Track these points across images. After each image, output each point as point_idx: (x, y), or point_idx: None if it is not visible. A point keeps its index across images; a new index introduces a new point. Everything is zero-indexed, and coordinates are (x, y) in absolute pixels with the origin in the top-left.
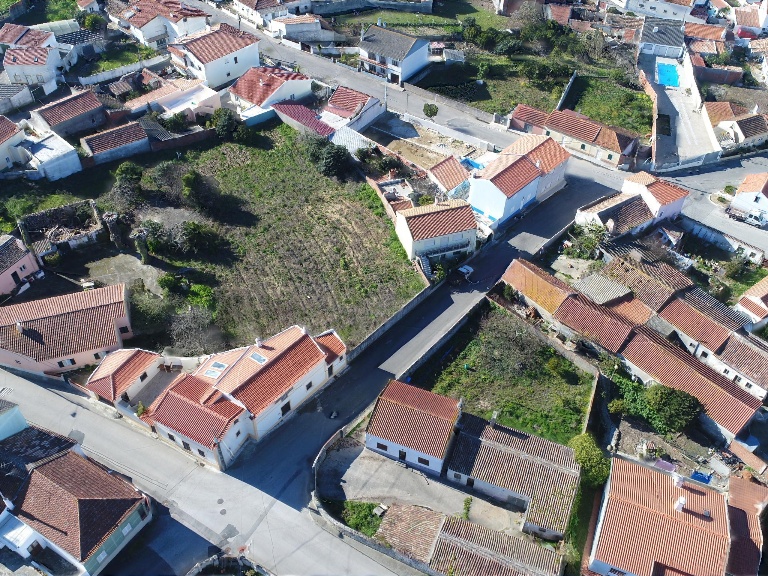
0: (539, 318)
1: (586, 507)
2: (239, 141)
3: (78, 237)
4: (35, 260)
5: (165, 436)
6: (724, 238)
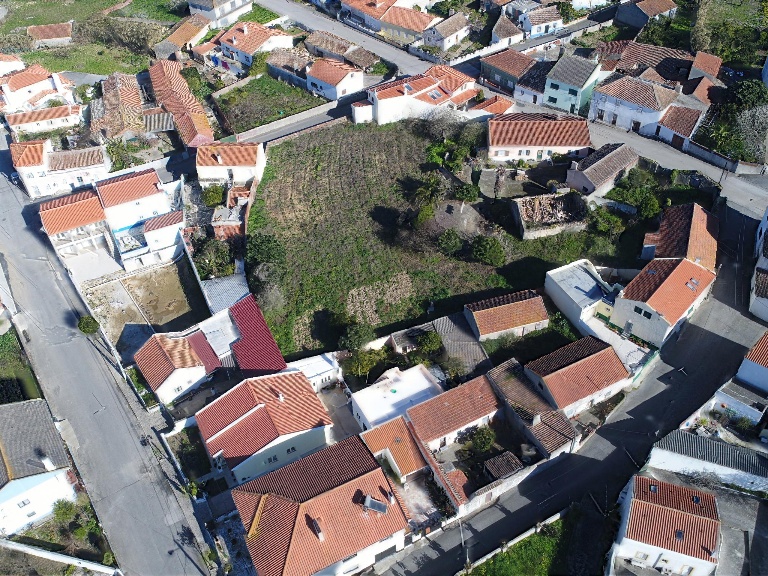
0: None
1: None
2: None
3: None
4: None
5: None
6: None
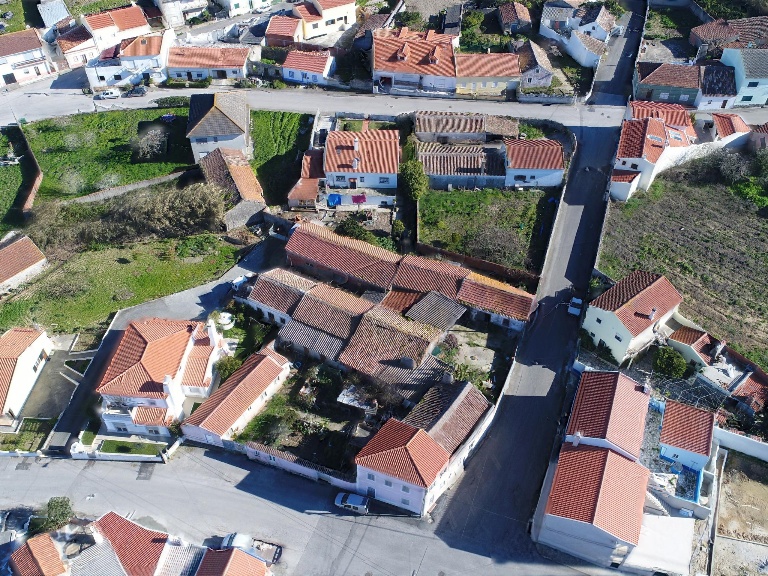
0: None
1: None
2: None
3: None
4: None
5: None
6: None
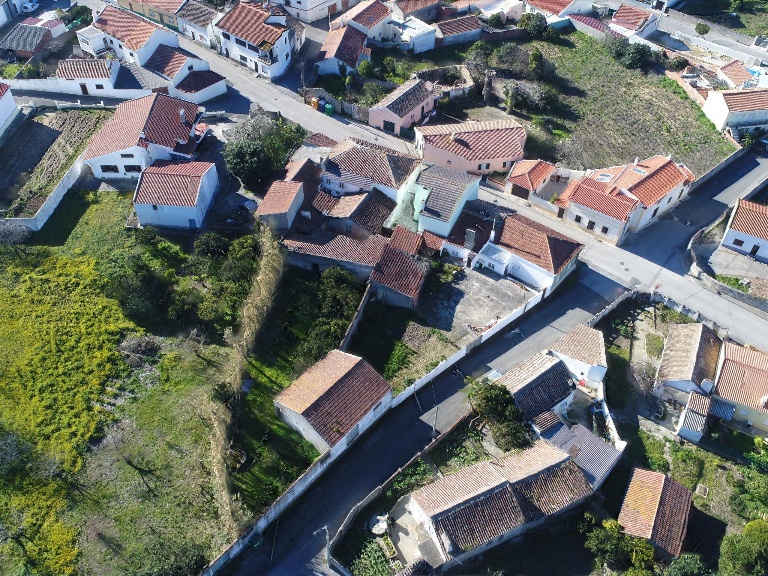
0: None
1: None
2: (547, 39)
3: (457, 89)
4: (432, 101)
5: (570, 219)
6: None
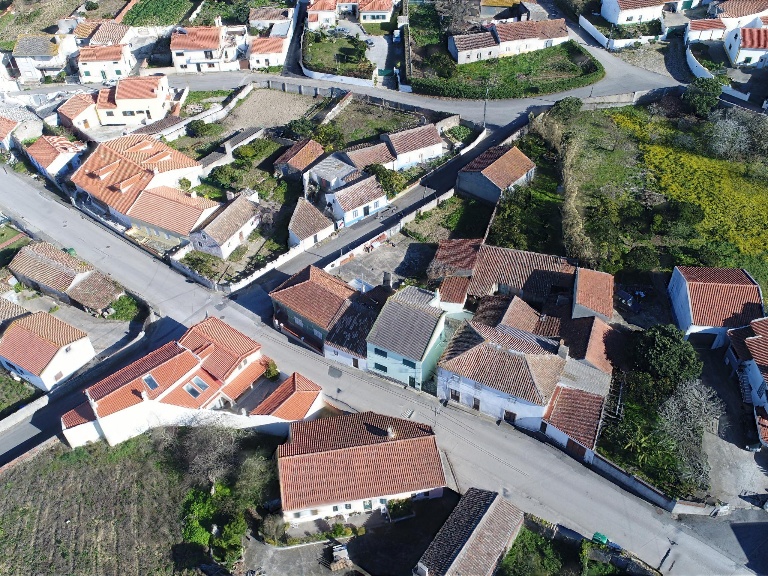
0: None
1: None
2: None
3: None
4: None
5: None
6: None
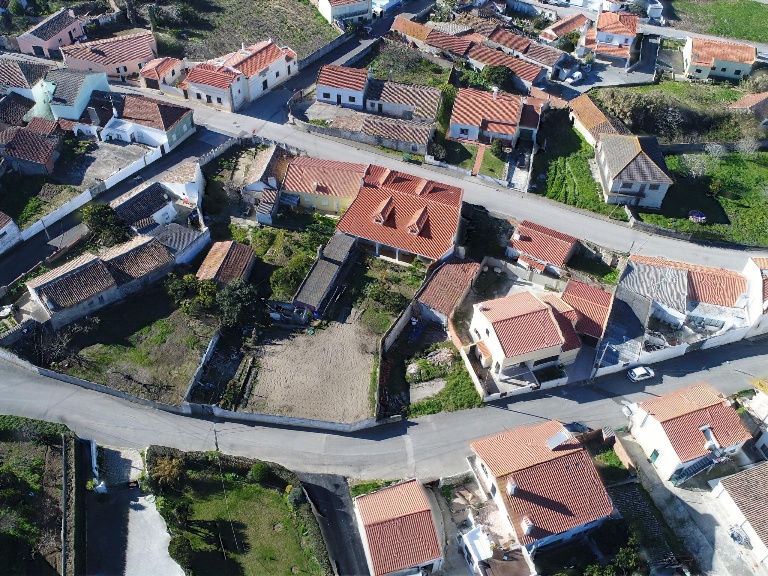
0: (416, 48)
1: (447, 113)
2: None
3: (105, 17)
4: (80, 27)
5: (194, 98)
6: (533, 7)
